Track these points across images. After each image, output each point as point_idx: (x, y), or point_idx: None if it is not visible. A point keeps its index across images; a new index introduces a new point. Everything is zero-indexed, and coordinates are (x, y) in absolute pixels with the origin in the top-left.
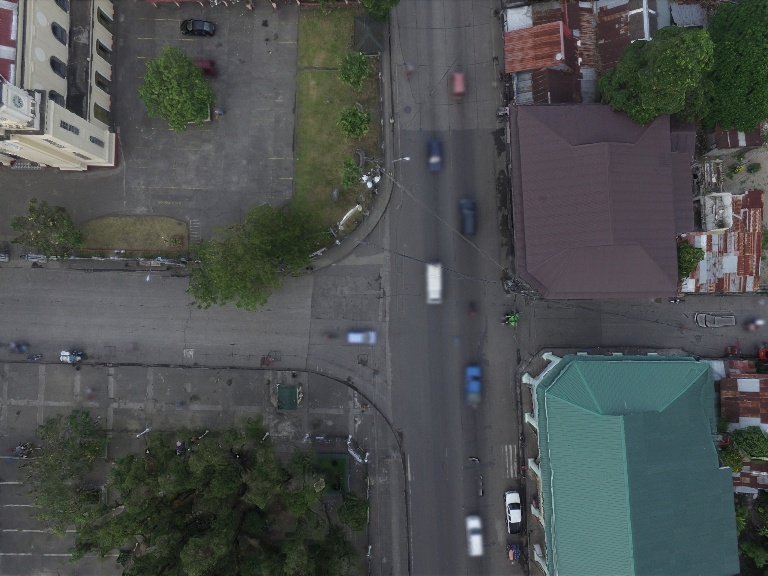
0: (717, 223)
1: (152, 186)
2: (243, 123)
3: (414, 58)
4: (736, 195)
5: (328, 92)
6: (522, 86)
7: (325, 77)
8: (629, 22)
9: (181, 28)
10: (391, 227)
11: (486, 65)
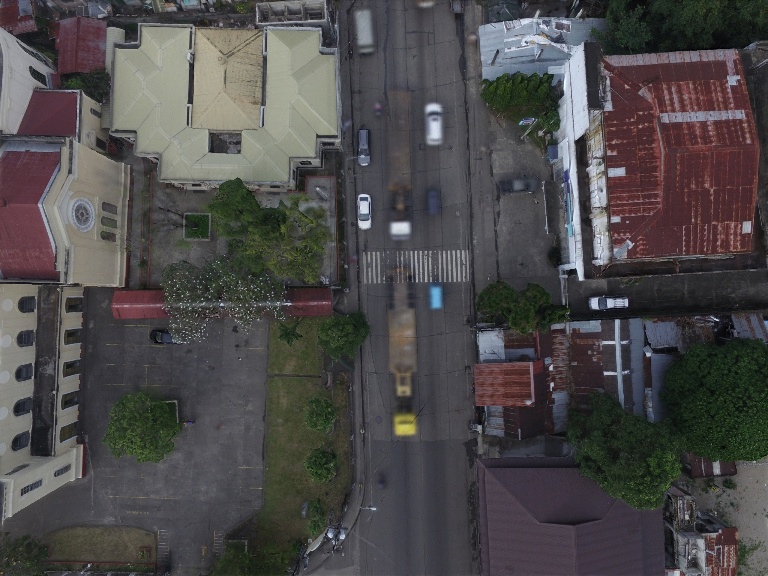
0: (690, 561)
1: (120, 495)
2: (212, 431)
3: (385, 367)
4: (709, 534)
5: (298, 400)
6: (493, 410)
7: (295, 385)
8: (601, 352)
9: (150, 337)
10: (361, 540)
11: (458, 374)
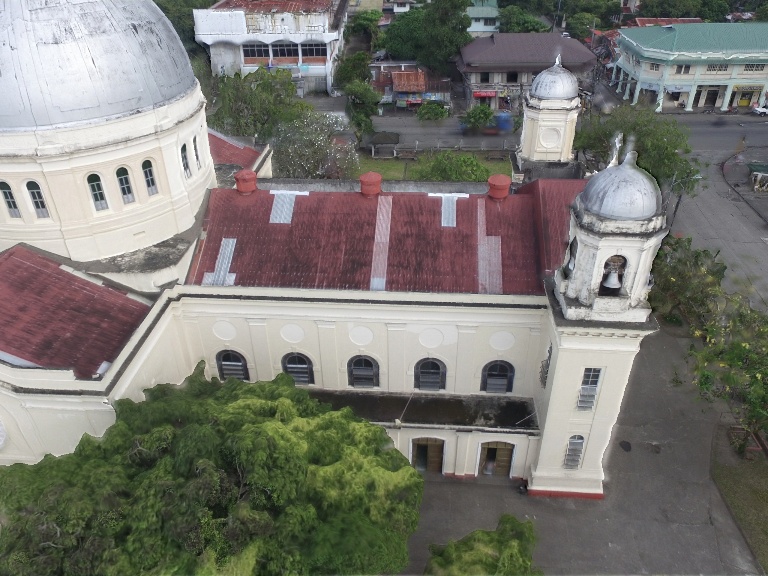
0: None
1: None
2: None
3: None
4: None
5: None
6: None
7: None
8: (389, 71)
9: None
10: None
11: None
